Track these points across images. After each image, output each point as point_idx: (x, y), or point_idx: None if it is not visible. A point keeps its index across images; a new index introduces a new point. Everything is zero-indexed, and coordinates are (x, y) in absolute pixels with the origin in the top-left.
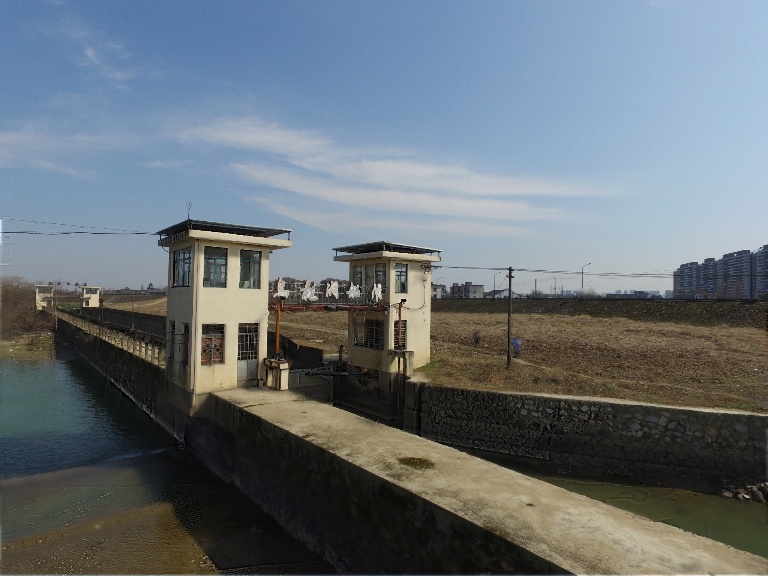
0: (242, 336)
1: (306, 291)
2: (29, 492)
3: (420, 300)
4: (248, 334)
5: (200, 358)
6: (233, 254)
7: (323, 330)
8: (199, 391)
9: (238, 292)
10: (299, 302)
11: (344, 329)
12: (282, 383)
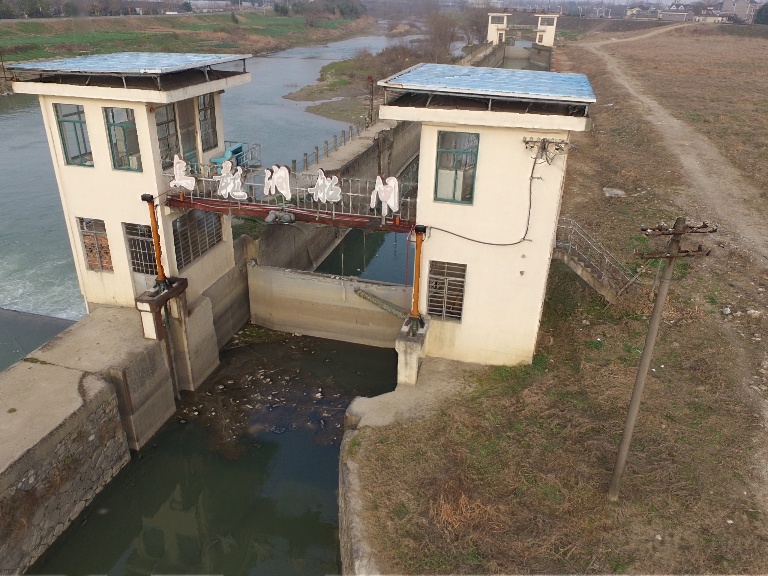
0: (134, 240)
1: (225, 181)
2: (2, 341)
3: (515, 224)
4: (140, 239)
5: (84, 260)
6: (93, 115)
7: (687, 162)
8: (92, 299)
9: (112, 176)
10: (220, 198)
11: (740, 166)
12: (146, 328)
